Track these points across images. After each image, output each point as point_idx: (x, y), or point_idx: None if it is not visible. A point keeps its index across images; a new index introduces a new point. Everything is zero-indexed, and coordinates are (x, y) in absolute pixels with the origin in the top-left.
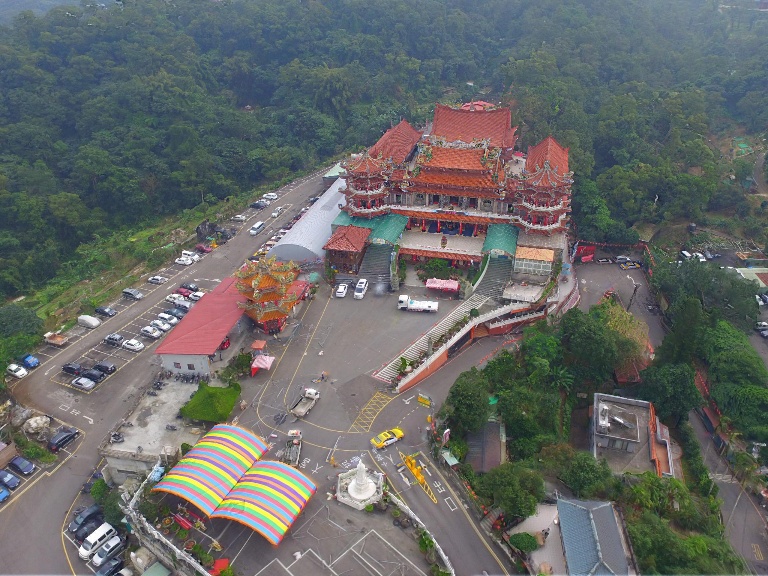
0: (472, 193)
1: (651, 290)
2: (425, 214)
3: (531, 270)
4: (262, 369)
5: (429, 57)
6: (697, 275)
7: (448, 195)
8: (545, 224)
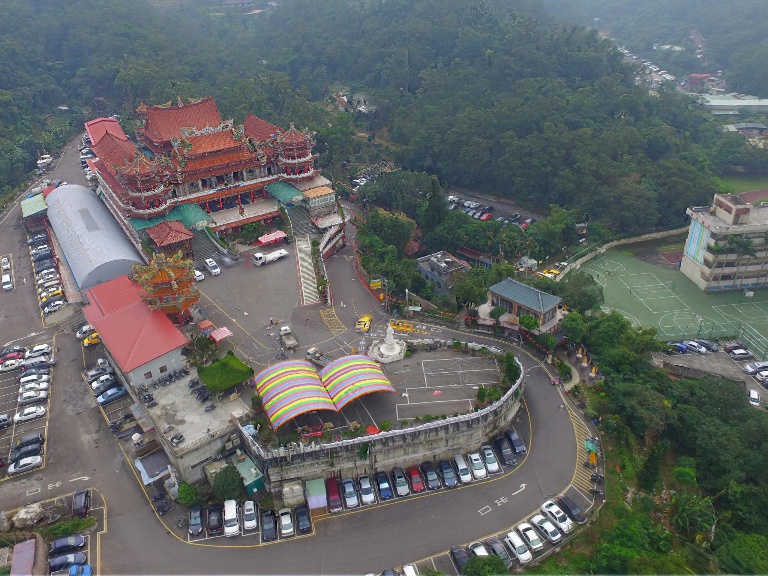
0: (238, 167)
1: (361, 208)
2: (208, 196)
3: (322, 204)
4: (218, 344)
5: (6, 88)
6: (396, 180)
7: (217, 175)
8: (306, 172)
